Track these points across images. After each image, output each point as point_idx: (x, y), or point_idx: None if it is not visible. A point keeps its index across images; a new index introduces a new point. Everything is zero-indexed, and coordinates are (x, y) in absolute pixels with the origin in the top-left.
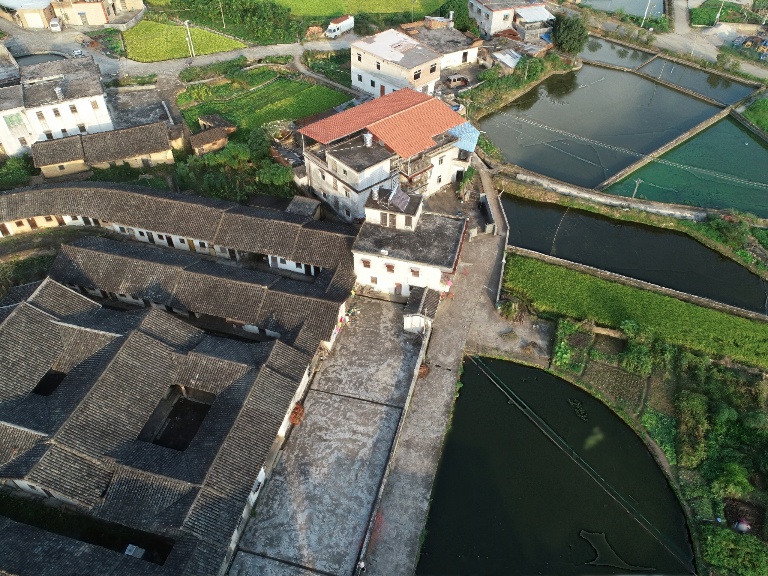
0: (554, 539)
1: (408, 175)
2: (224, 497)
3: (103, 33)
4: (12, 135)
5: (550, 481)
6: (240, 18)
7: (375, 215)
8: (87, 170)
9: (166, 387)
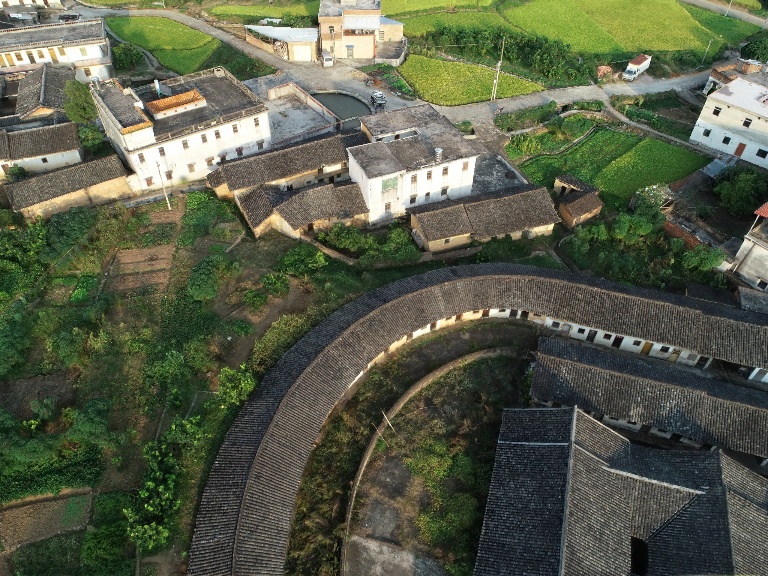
0: None
1: None
2: None
3: (377, 69)
4: (381, 200)
5: None
6: (516, 54)
7: None
8: (468, 243)
9: None
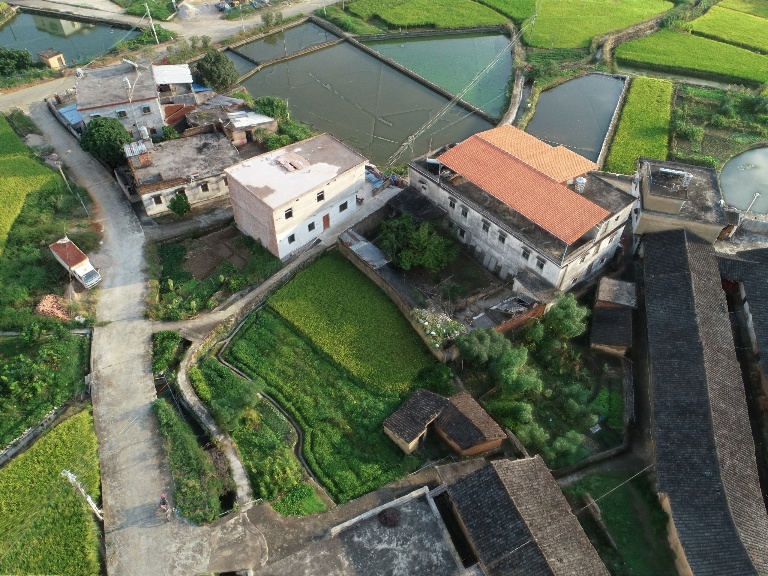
0: None
1: None
2: None
3: None
4: None
5: None
6: None
7: None
8: None
9: None
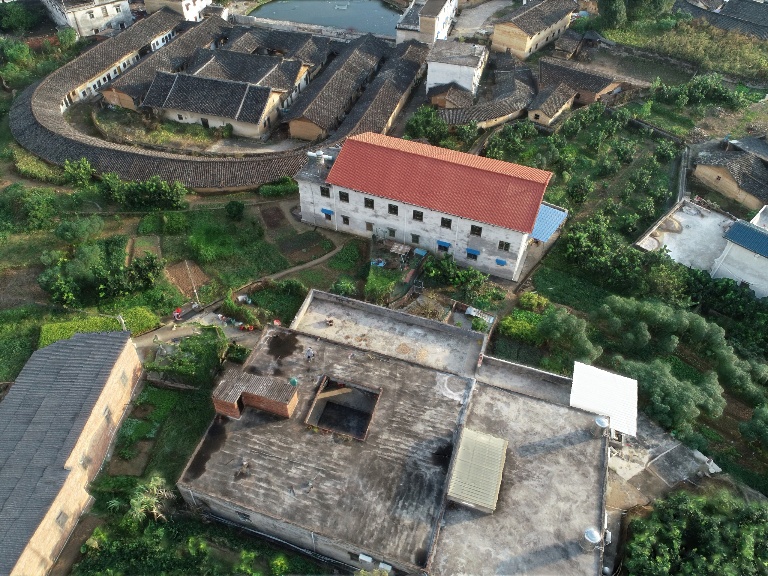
0: None
1: None
2: None
3: None
4: None
5: None
6: None
7: None
8: None
9: None
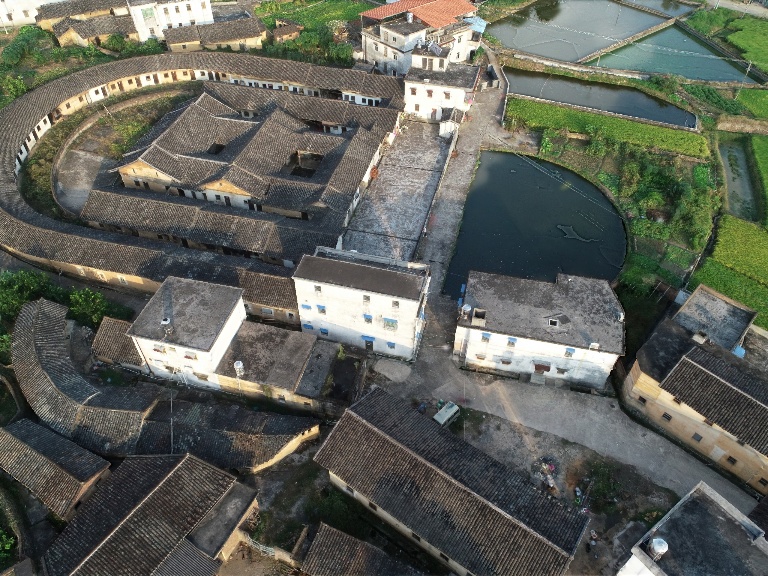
0: (541, 228)
1: (438, 43)
2: (341, 193)
3: None
4: (145, 25)
5: (538, 205)
6: None
7: (418, 60)
8: None
9: (292, 150)
